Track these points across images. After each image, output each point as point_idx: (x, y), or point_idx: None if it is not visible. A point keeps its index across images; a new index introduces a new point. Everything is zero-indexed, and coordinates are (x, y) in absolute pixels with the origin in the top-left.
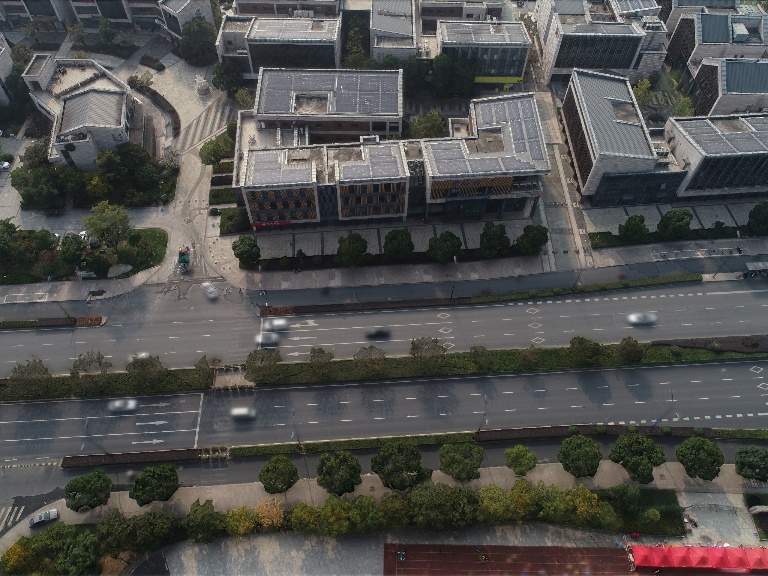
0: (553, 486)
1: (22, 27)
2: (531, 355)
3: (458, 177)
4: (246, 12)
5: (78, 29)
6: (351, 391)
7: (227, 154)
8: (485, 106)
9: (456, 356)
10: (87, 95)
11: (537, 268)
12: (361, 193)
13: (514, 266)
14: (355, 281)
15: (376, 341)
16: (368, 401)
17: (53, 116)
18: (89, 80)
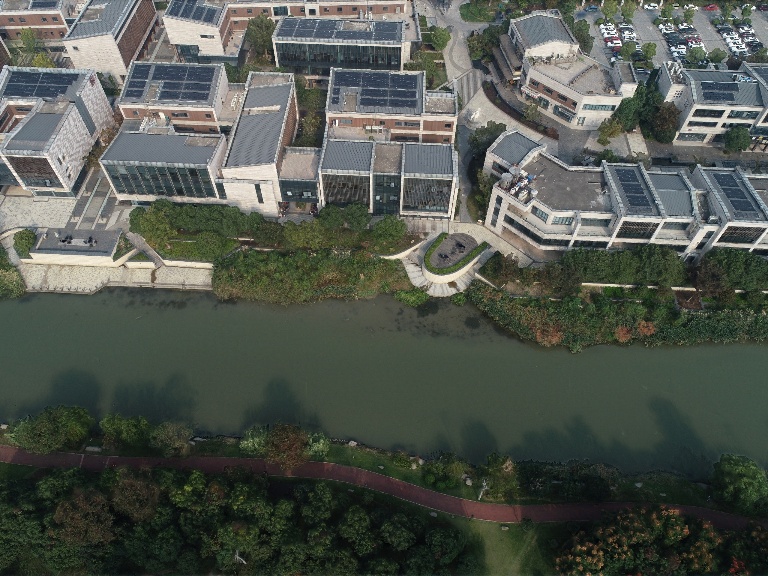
0: None
1: None
2: None
3: None
4: None
5: None
6: None
7: None
8: (208, 21)
9: None
10: None
11: None
12: None
13: None
14: None
15: None
16: None
17: None
18: (575, 81)
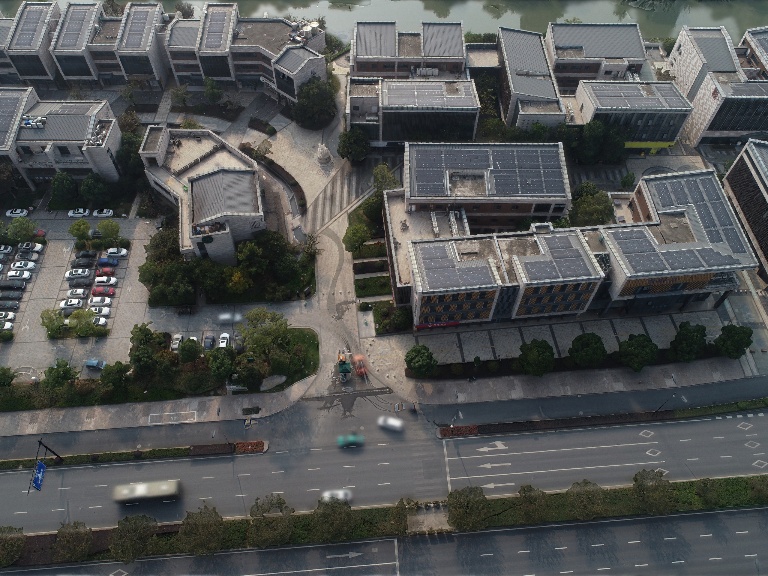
0: None
1: (120, 89)
2: (767, 489)
3: (656, 275)
4: (364, 70)
5: (182, 91)
6: (564, 533)
7: None
8: (659, 184)
9: (675, 487)
10: (217, 176)
11: (737, 372)
12: (545, 293)
13: (711, 370)
14: (538, 391)
15: (578, 468)
16: (586, 546)
17: (173, 196)
18: (208, 154)
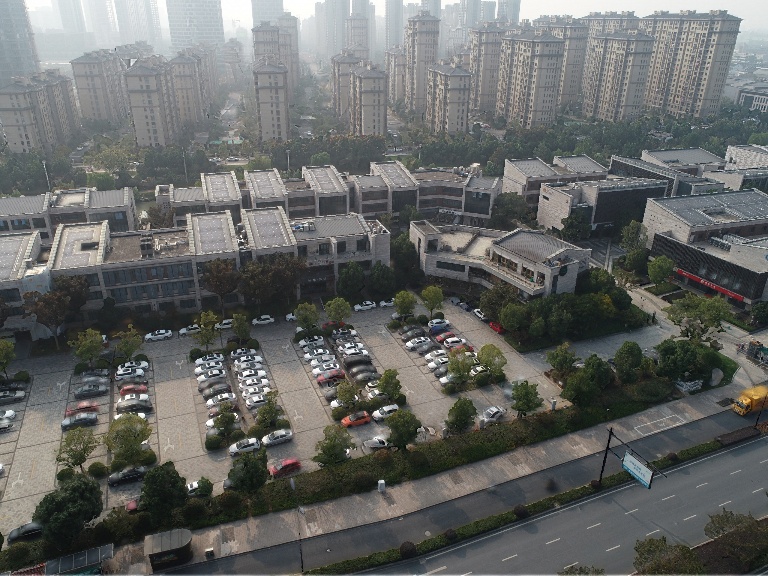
0: None
1: None
2: None
3: None
4: (532, 189)
5: None
6: None
7: (646, 280)
8: None
9: None
10: (520, 235)
11: None
12: None
13: None
14: None
15: None
16: None
17: (469, 268)
18: None
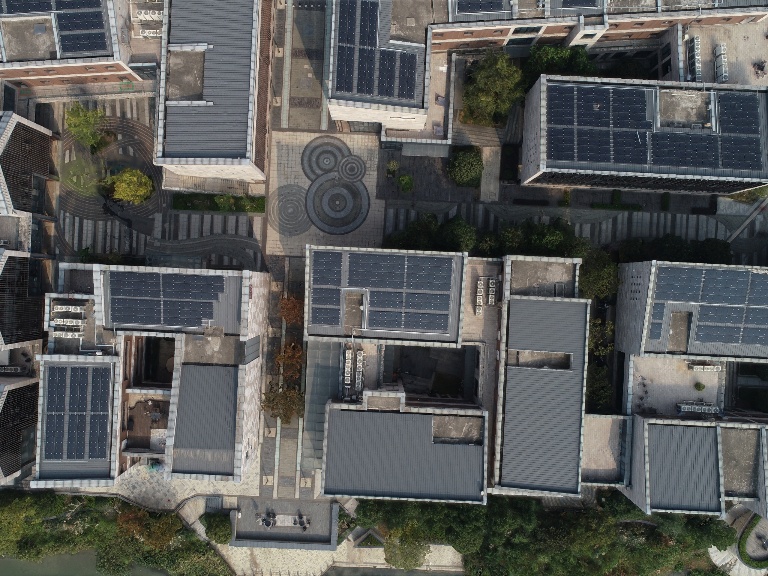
0: None
1: None
2: None
3: None
4: None
5: None
6: None
7: None
8: (408, 96)
9: None
10: None
11: None
12: None
13: None
14: None
15: None
16: None
17: None
18: None
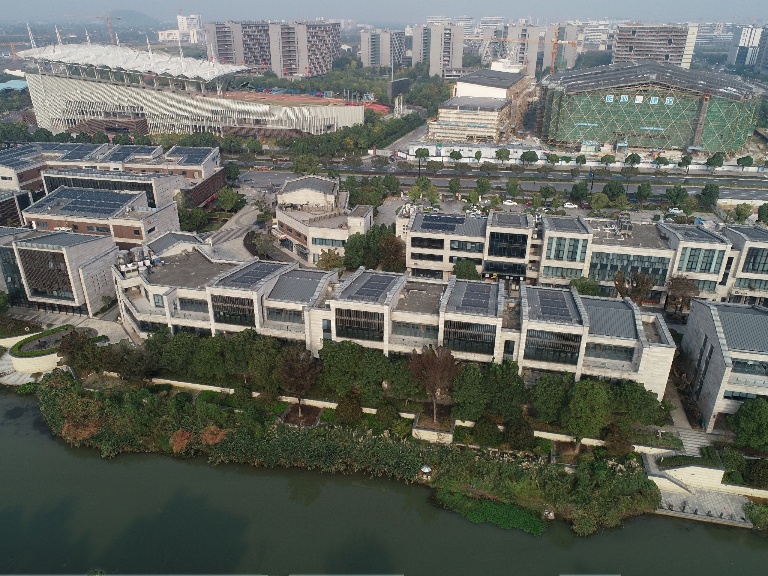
0: (161, 136)
1: None
2: None
3: None
4: None
5: None
6: None
7: None
8: (11, 166)
9: None
10: None
11: None
12: None
13: None
14: None
15: None
16: None
17: None
18: (315, 220)
